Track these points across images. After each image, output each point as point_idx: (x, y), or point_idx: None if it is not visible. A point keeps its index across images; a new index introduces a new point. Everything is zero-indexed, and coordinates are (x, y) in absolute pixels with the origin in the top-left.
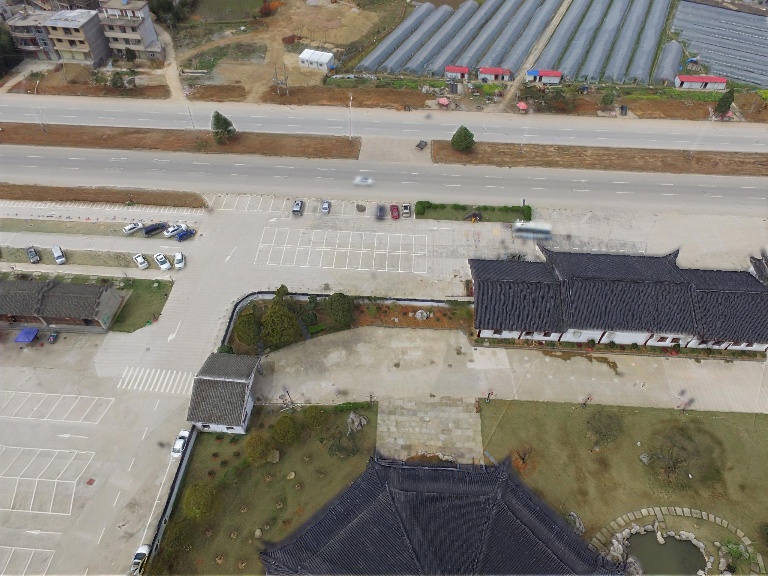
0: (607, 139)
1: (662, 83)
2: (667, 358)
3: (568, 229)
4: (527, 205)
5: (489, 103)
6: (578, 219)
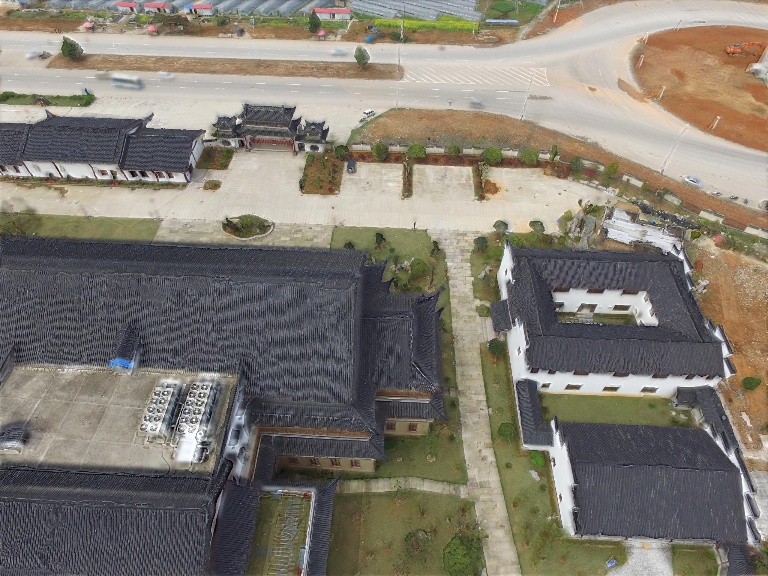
0: (209, 52)
1: (302, 15)
2: (111, 188)
3: (115, 111)
4: (94, 95)
5: (136, 28)
6: (130, 104)
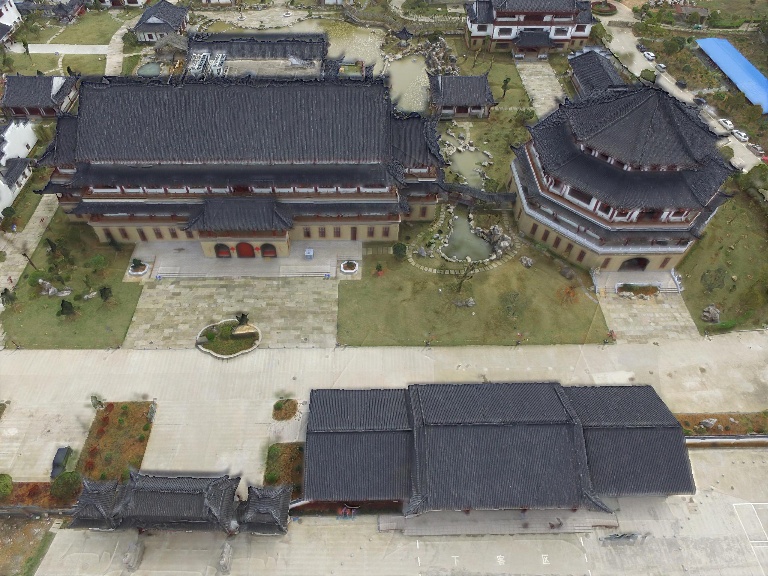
0: None
1: None
2: None
3: None
4: None
5: None
6: None
